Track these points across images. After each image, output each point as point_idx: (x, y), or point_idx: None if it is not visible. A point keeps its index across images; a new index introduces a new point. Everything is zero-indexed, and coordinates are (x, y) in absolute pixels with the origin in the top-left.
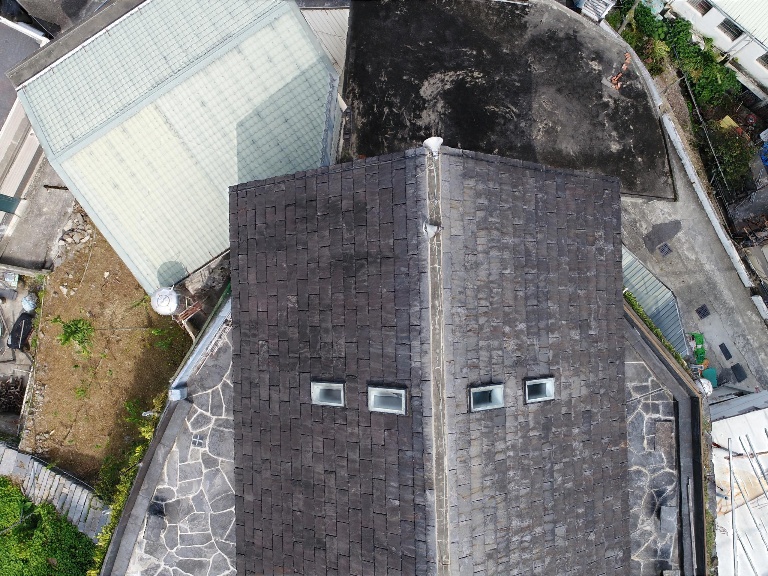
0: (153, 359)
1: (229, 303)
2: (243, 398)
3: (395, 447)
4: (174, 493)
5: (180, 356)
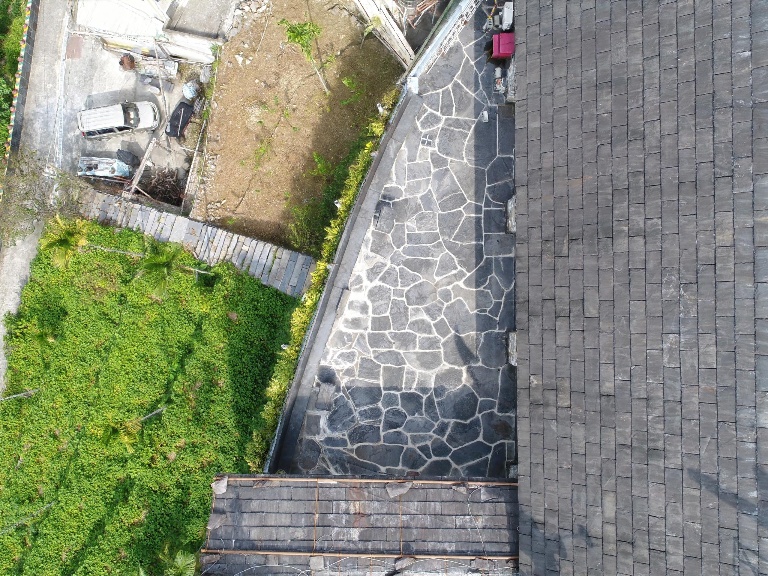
0: (333, 123)
1: None
2: (529, 27)
3: None
4: (402, 192)
5: (362, 118)
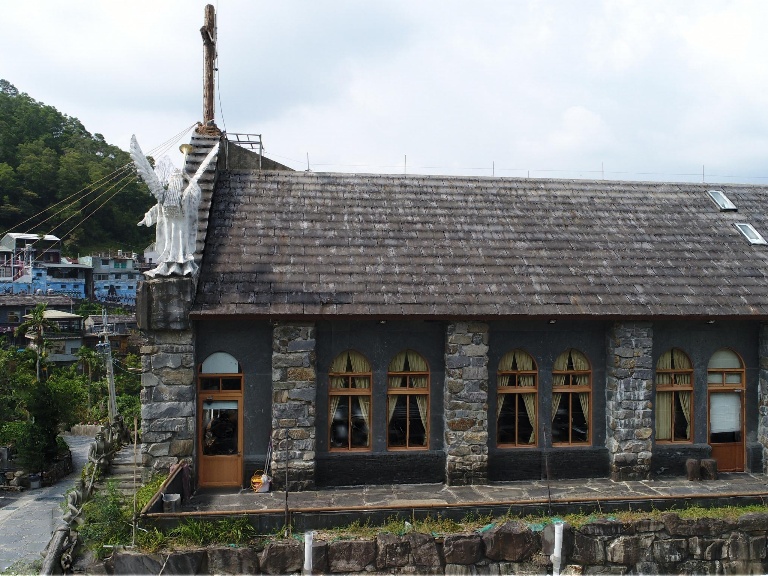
0: None
1: None
2: None
3: None
4: None
5: None
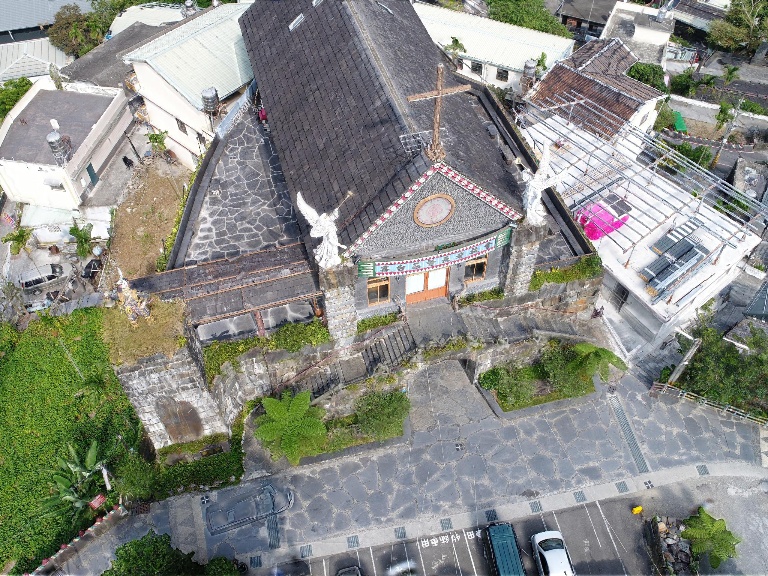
0: None
1: (241, 97)
2: (258, 66)
3: (327, 6)
4: (223, 179)
5: None
